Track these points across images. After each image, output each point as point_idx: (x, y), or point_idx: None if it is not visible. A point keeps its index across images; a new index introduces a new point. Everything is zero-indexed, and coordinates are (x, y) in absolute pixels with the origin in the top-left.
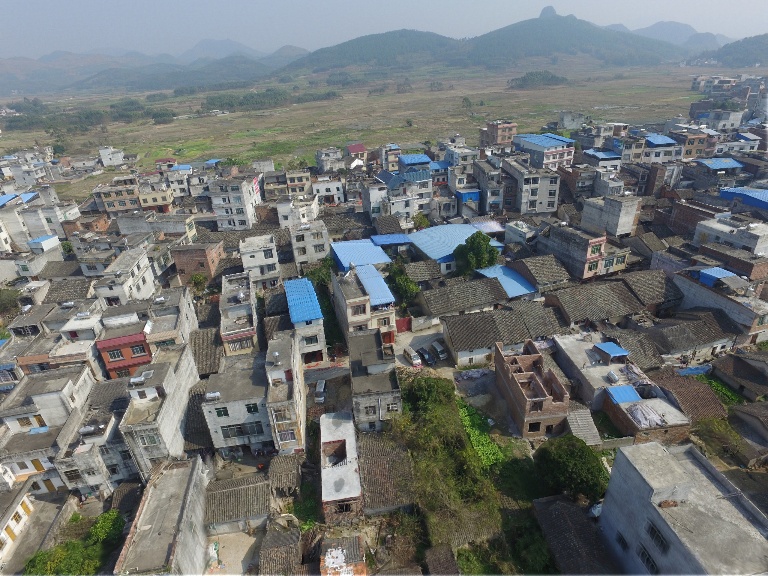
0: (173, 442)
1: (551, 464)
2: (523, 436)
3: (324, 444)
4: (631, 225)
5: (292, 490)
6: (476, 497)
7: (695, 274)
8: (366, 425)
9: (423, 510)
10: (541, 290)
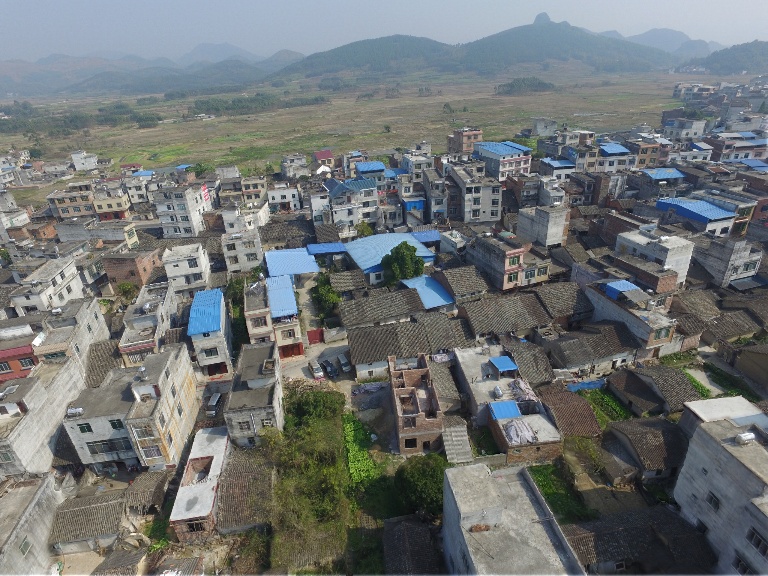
0: (34, 458)
1: (404, 483)
2: (400, 452)
3: (192, 460)
4: (561, 236)
5: (146, 508)
6: (328, 516)
7: (603, 287)
8: (245, 440)
9: (274, 529)
10: (459, 301)
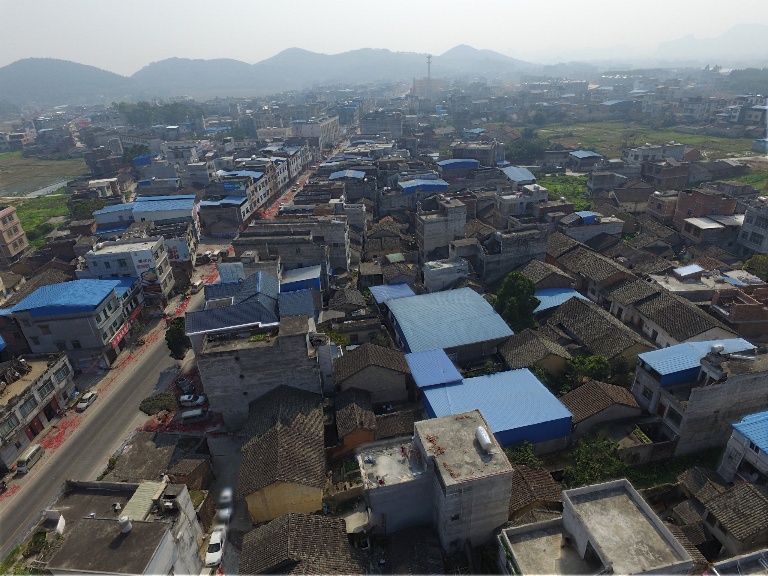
0: None
1: None
2: None
3: None
4: None
5: None
6: None
7: None
8: None
9: None
10: None
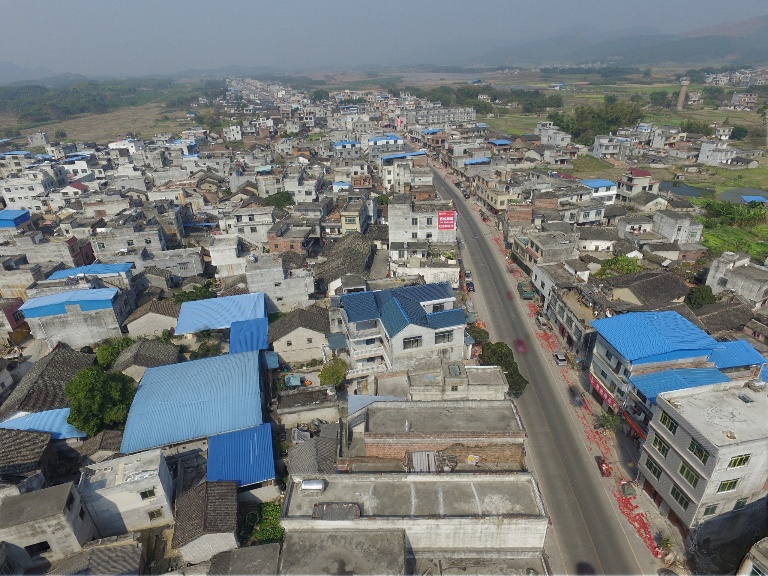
0: None
1: None
2: None
3: None
4: None
5: None
6: None
7: None
8: None
9: None
10: None
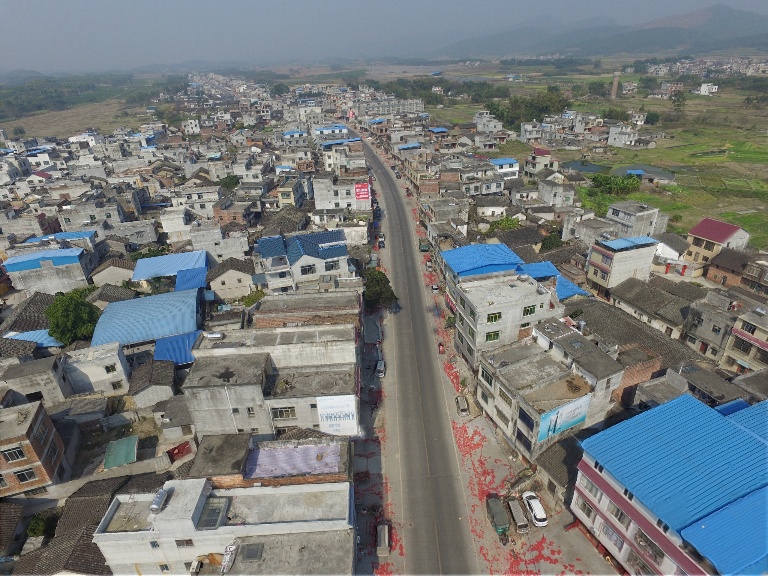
0: None
1: None
2: None
3: None
4: None
5: None
6: None
7: None
8: None
9: None
10: None
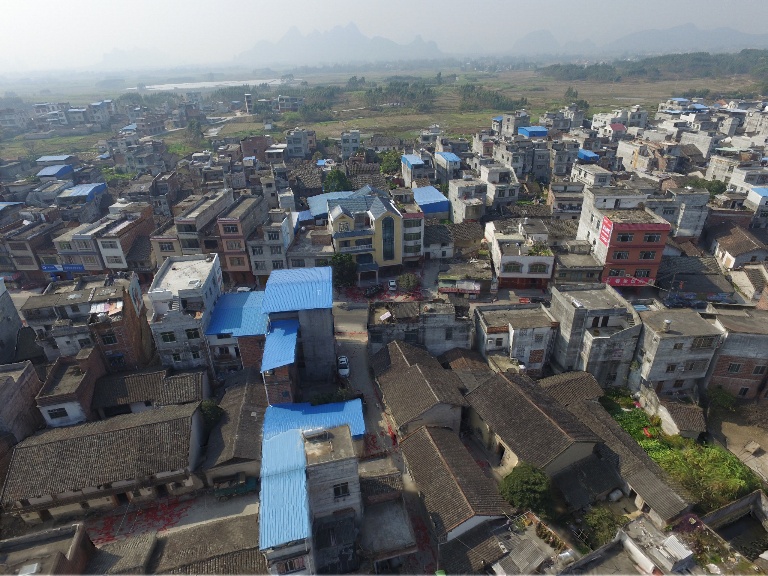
0: None
1: None
2: None
3: None
4: None
5: None
6: None
7: None
8: None
9: None
10: None
